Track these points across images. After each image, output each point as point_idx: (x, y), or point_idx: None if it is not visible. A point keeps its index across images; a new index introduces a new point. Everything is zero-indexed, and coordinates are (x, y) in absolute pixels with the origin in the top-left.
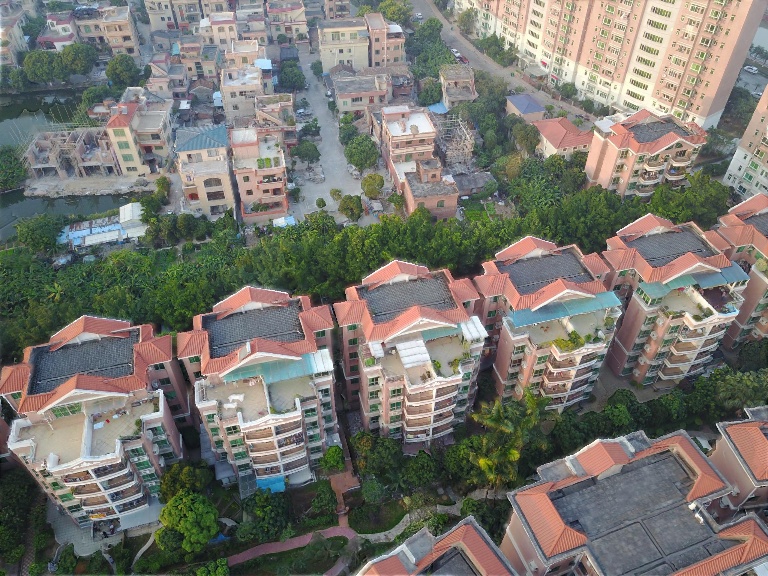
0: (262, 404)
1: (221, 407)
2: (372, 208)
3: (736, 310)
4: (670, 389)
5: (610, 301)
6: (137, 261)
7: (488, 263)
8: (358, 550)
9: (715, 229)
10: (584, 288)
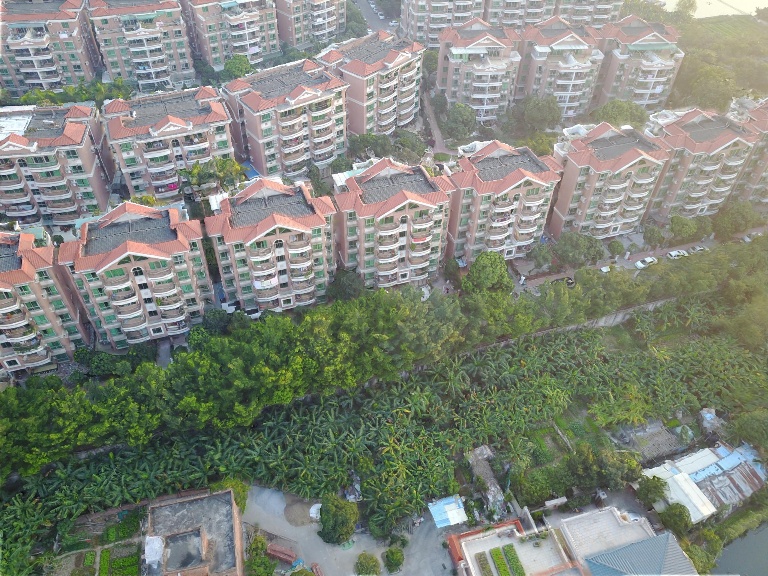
0: None
1: None
2: None
3: None
4: None
5: (85, 220)
6: None
7: (183, 242)
8: None
9: None
10: None
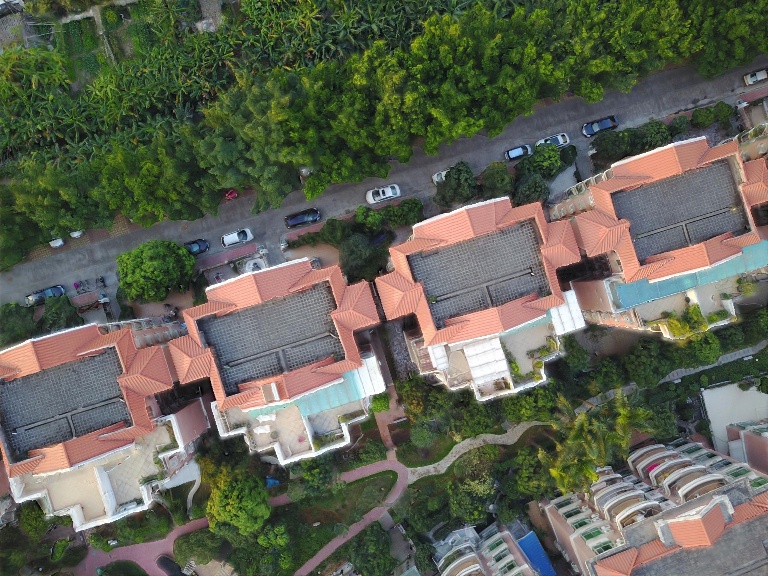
0: (300, 423)
1: (251, 432)
2: None
3: None
4: None
5: (759, 259)
6: (41, 63)
7: (601, 193)
8: (411, 504)
9: None
10: (731, 244)
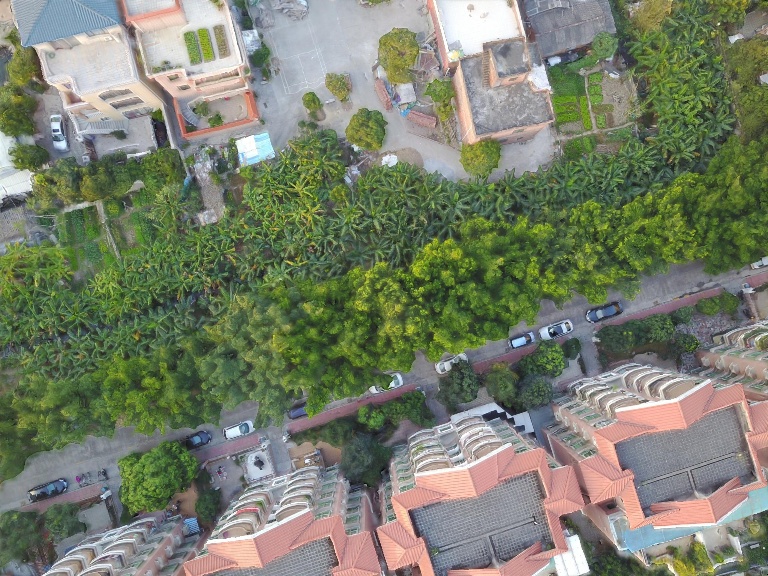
0: None
1: None
2: (398, 99)
3: None
4: None
5: (766, 503)
6: (43, 258)
7: (604, 442)
8: None
9: None
10: (737, 492)
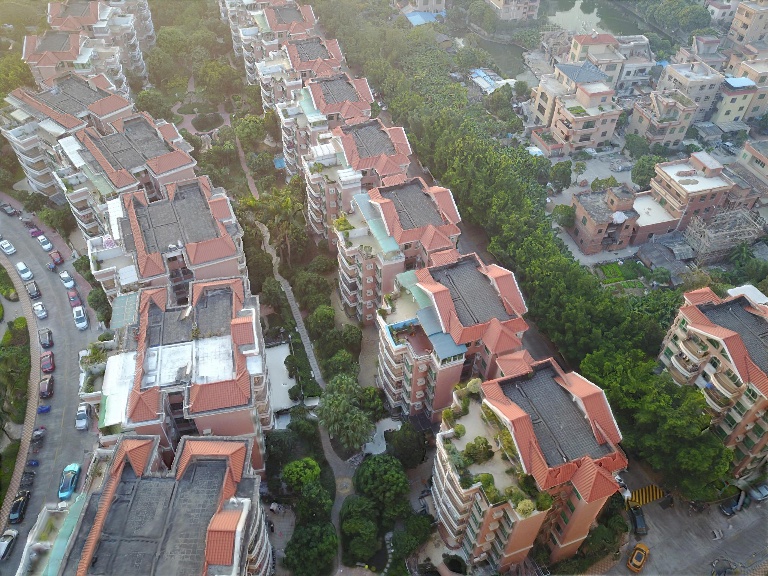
0: None
1: None
2: None
3: (397, 345)
4: (377, 386)
5: (386, 245)
6: None
7: None
8: None
9: (705, 525)
10: (395, 225)
